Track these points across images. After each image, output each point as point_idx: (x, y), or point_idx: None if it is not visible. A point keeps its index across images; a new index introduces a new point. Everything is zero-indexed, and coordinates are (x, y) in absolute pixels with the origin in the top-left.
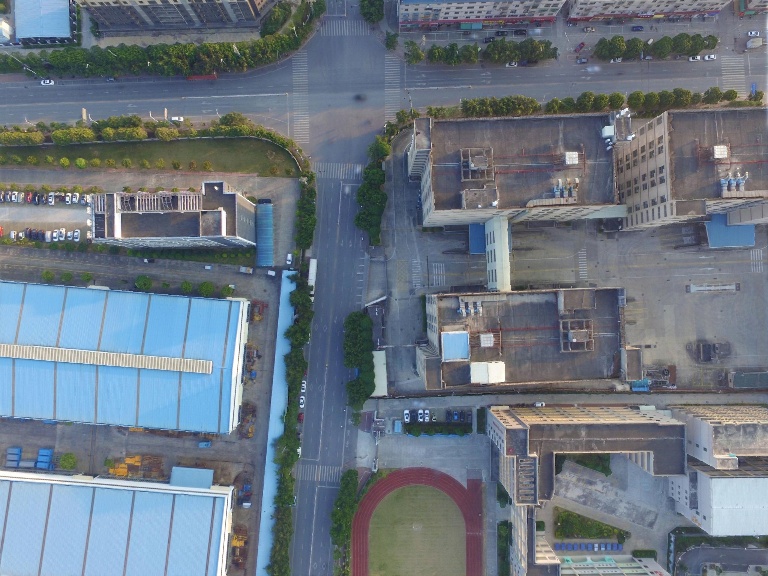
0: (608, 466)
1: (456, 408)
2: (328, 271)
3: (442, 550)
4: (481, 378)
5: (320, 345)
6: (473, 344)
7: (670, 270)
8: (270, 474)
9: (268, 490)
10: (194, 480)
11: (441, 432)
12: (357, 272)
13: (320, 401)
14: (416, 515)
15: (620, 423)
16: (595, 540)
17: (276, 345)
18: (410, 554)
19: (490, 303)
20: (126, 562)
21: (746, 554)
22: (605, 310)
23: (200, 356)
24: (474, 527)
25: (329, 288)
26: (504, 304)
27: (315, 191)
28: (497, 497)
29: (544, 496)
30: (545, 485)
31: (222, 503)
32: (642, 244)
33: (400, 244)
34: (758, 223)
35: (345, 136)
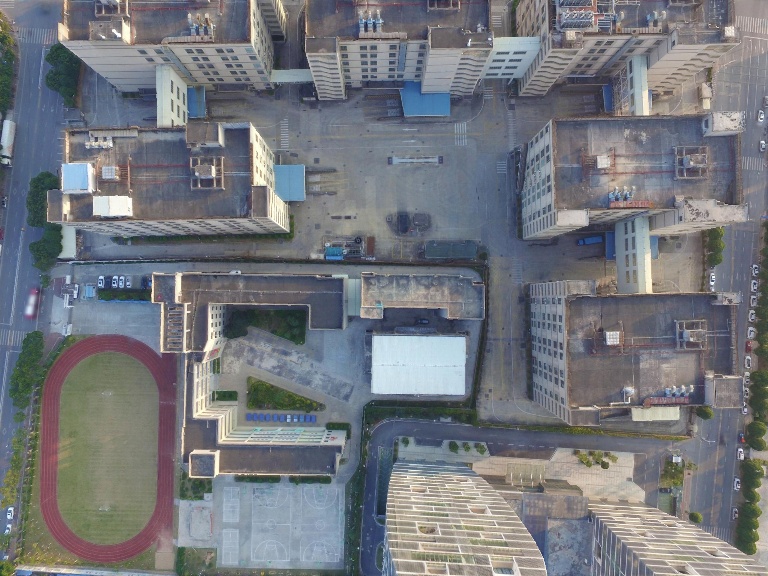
0: (303, 336)
1: None
2: (28, 136)
3: (134, 418)
4: (102, 210)
5: (18, 209)
6: (100, 178)
7: (373, 142)
8: None
9: None
10: None
11: (133, 298)
12: (58, 137)
13: (15, 265)
14: (109, 382)
15: (278, 275)
16: (289, 411)
17: None
18: (101, 422)
19: (123, 140)
20: None
21: (441, 429)
22: (240, 149)
23: None
24: (168, 396)
25: (29, 153)
26: (137, 141)
27: (16, 55)
28: None
29: (198, 347)
30: (200, 336)
31: None
32: (345, 115)
33: (101, 110)
34: (451, 91)
35: (50, 2)
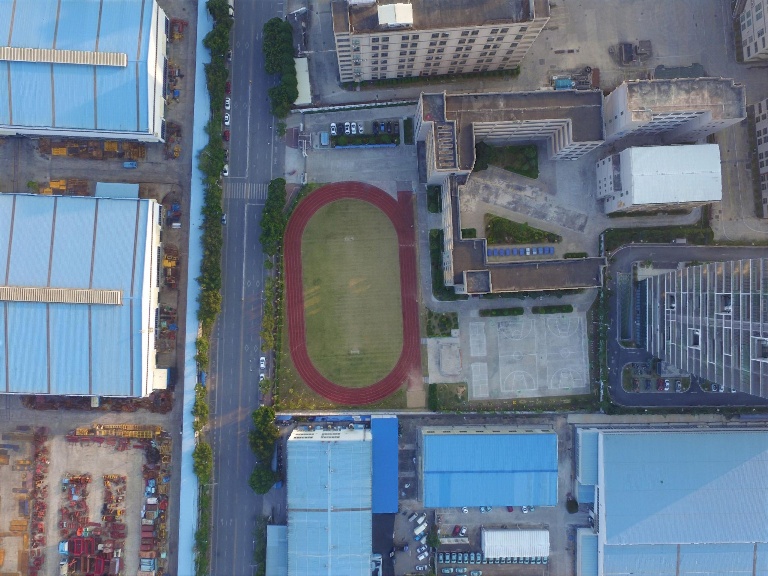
0: None
1: (383, 120)
2: None
3: (375, 263)
4: (388, 18)
5: (243, 62)
6: None
7: None
8: (196, 185)
9: (195, 203)
10: (119, 194)
11: (368, 142)
12: None
13: (245, 118)
14: (348, 229)
15: (537, 92)
16: (527, 245)
17: (196, 56)
18: (344, 268)
19: None
20: (51, 265)
21: (675, 251)
22: None
23: (114, 50)
24: (406, 239)
25: (249, 4)
26: None
27: None
28: (428, 207)
29: (465, 167)
30: (466, 157)
31: (146, 205)
32: None
33: None
34: None
35: None
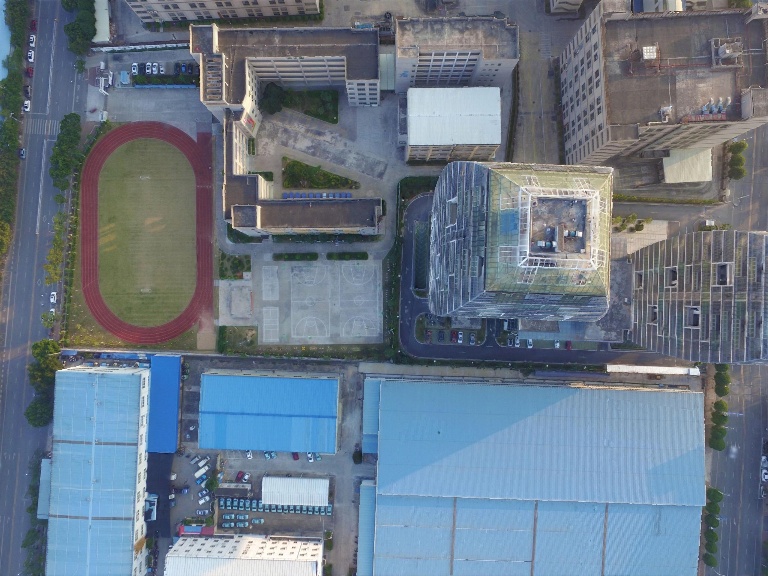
0: (336, 116)
1: (185, 61)
2: None
3: (172, 203)
4: None
5: (50, 1)
6: None
7: None
8: None
9: None
10: None
11: (167, 82)
12: None
13: (49, 55)
14: (146, 168)
15: (313, 29)
16: (324, 190)
17: None
18: (139, 207)
19: None
20: None
21: None
22: None
23: None
24: (204, 180)
25: None
26: None
27: None
28: None
29: (237, 101)
30: (238, 91)
31: None
32: None
33: None
34: None
35: None
